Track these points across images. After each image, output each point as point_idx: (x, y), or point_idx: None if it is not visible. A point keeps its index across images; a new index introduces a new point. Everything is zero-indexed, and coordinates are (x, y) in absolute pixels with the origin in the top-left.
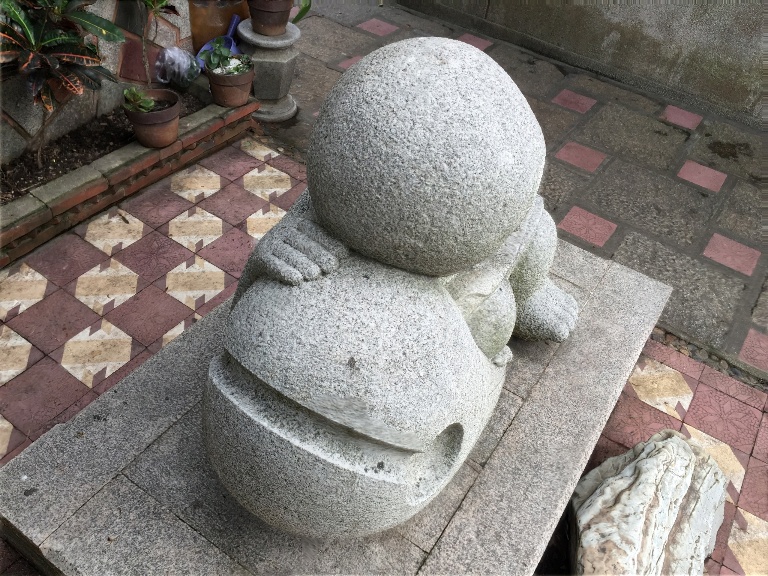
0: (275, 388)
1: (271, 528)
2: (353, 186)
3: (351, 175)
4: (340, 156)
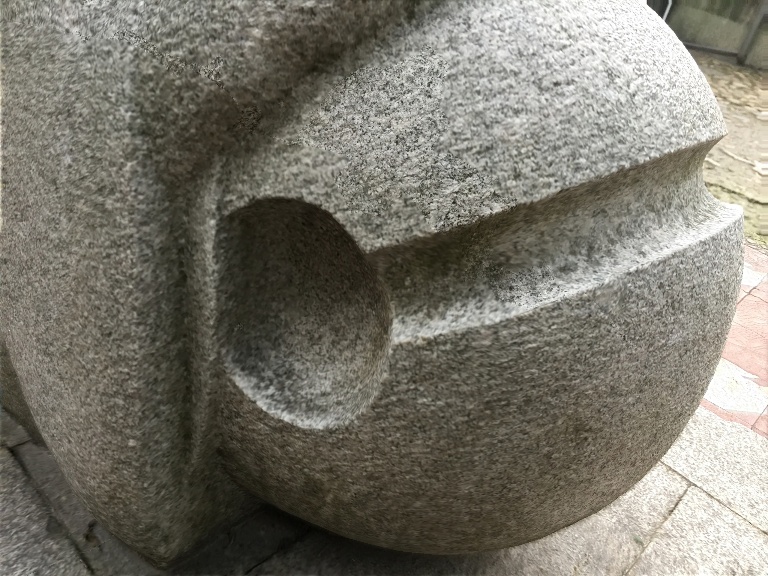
0: (708, 139)
1: (514, 555)
2: None
3: None
4: None
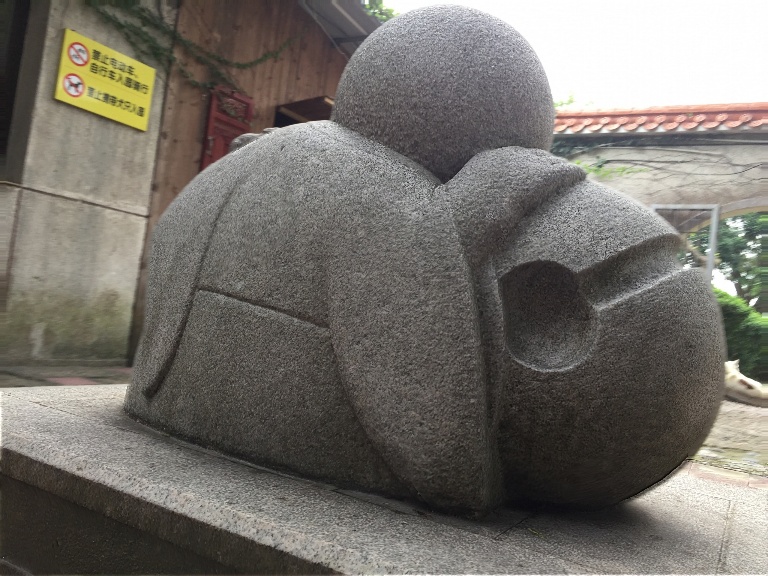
0: None
1: (658, 519)
2: (549, 86)
3: (546, 77)
4: (536, 62)
